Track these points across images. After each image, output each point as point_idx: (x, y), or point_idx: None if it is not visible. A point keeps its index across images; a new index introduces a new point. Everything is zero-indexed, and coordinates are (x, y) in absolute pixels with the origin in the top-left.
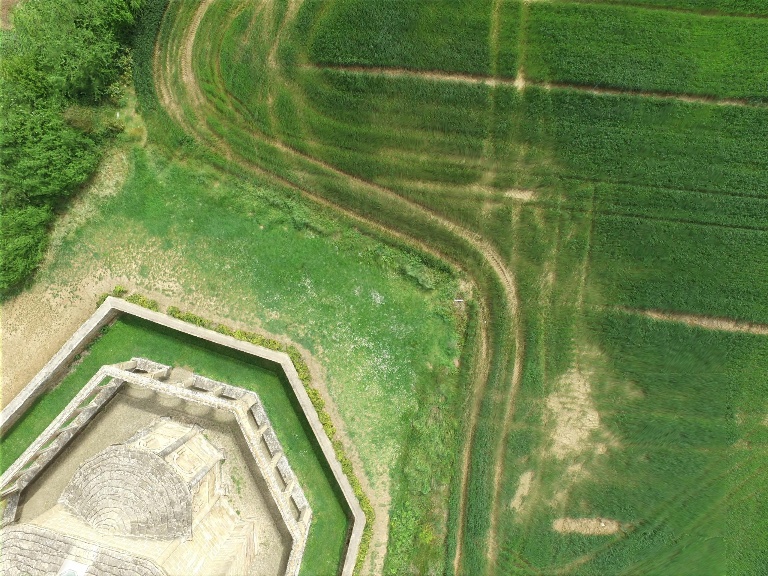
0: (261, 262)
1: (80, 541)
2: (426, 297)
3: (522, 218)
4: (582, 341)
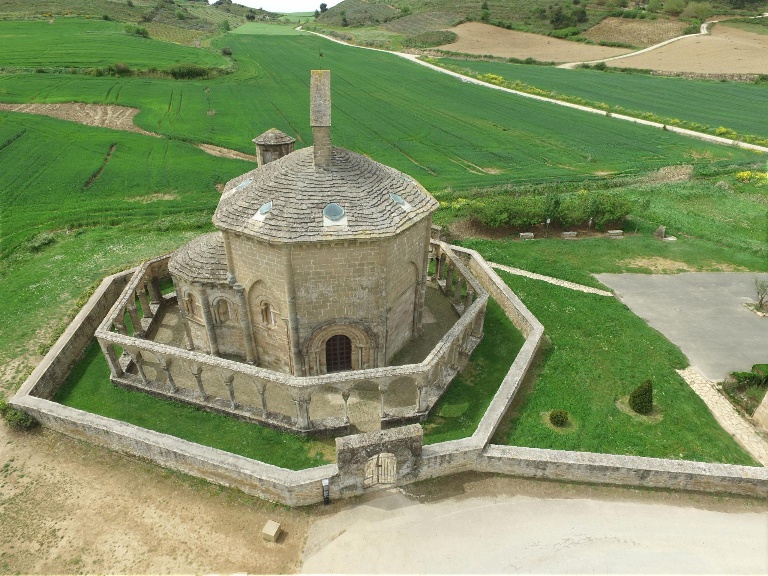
0: (0, 314)
1: None
2: None
3: (3, 223)
4: None
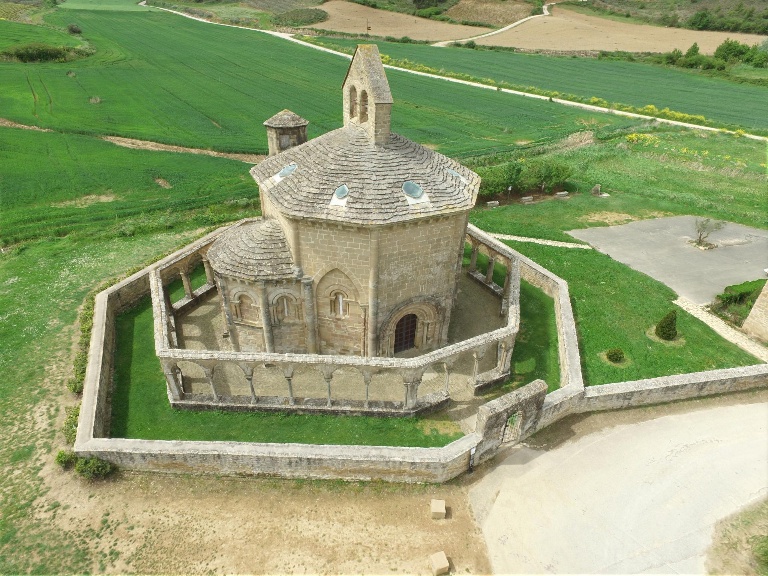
0: None
1: (264, 191)
2: (3, 263)
3: None
4: (25, 208)
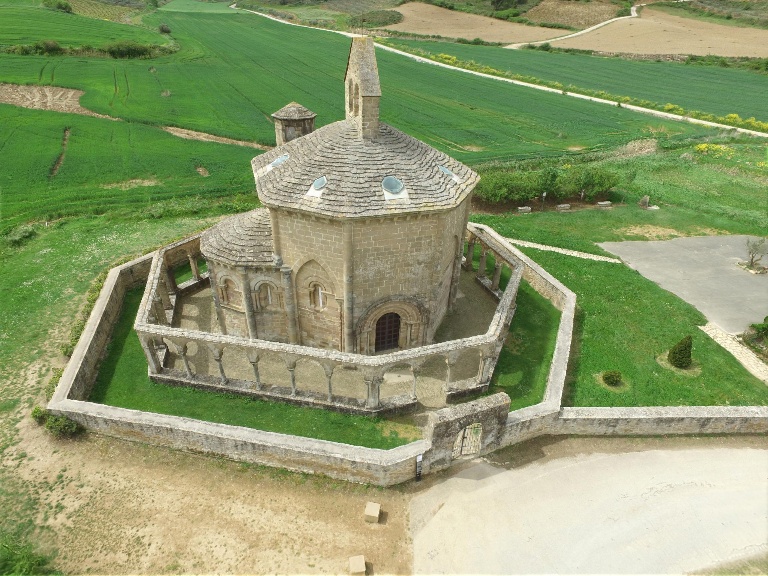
0: None
1: None
2: (44, 235)
3: None
4: None
